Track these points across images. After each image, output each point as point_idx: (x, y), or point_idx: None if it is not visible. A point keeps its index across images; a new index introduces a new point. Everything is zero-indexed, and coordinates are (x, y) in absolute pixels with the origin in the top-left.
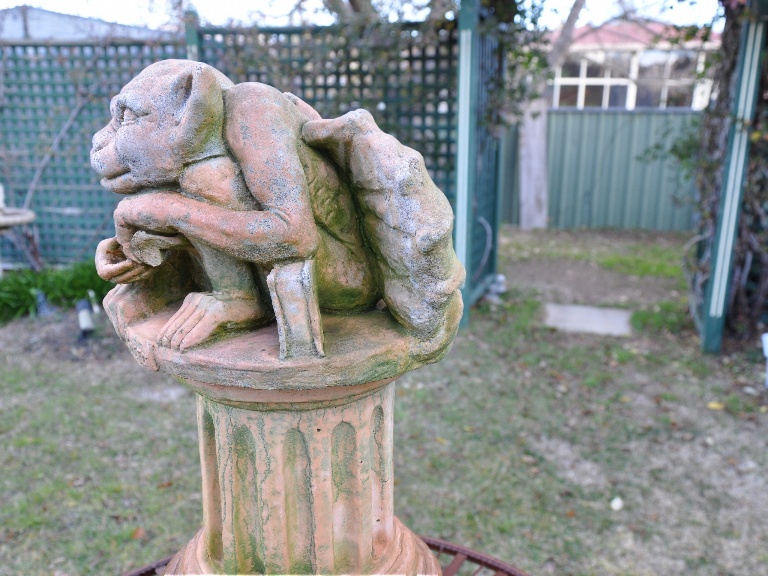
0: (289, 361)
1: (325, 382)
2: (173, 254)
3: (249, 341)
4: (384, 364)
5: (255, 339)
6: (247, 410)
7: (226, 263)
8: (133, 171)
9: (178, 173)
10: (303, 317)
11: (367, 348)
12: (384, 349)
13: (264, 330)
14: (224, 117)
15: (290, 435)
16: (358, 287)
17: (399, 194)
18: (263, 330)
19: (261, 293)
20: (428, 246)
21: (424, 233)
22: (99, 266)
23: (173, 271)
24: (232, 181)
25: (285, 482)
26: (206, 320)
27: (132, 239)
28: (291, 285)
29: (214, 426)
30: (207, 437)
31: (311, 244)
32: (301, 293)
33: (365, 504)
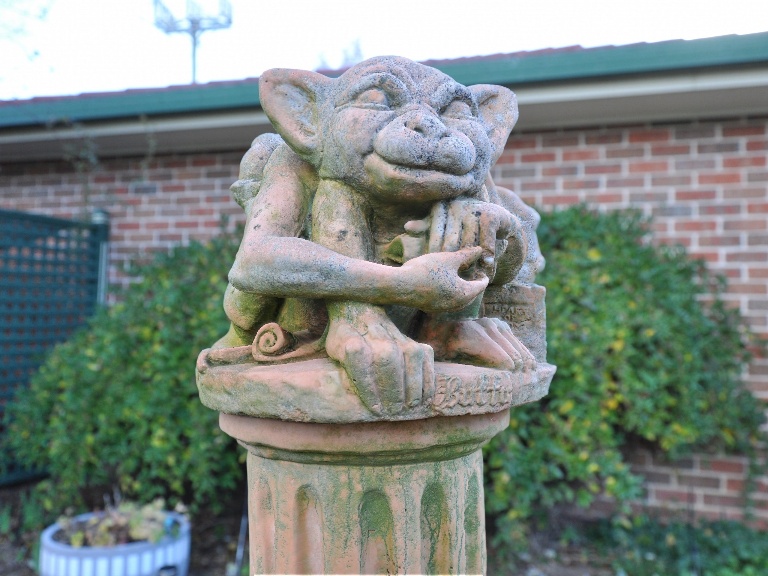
0: None
1: None
2: None
3: None
4: None
5: None
6: None
7: None
8: (480, 171)
9: None
10: None
11: None
12: None
13: None
14: None
15: None
16: None
17: (532, 230)
18: None
19: None
20: None
21: None
22: None
23: None
24: None
25: None
26: None
27: None
28: None
29: (450, 493)
30: None
31: None
32: None
33: None
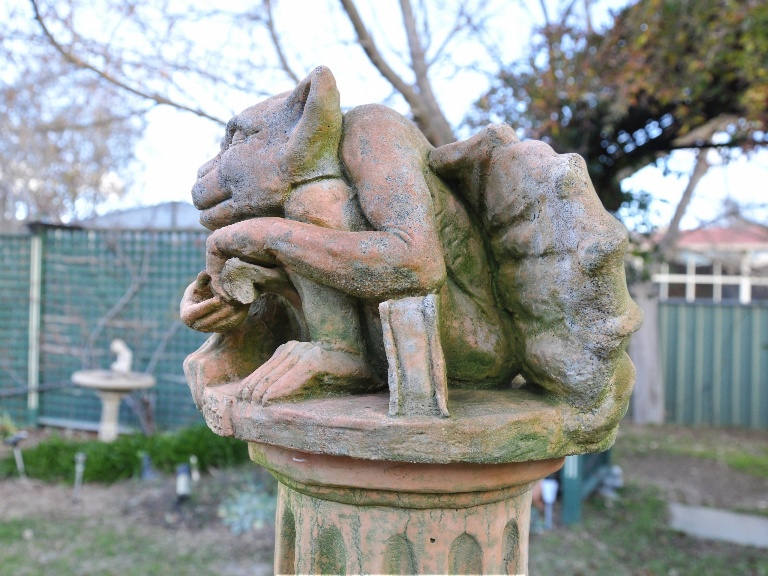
0: (401, 418)
1: (448, 453)
2: (269, 311)
3: (350, 399)
4: (529, 438)
5: (357, 399)
6: (339, 503)
7: (329, 303)
8: (234, 194)
9: (284, 195)
10: (423, 359)
11: (506, 412)
12: (529, 415)
13: (369, 395)
14: (342, 134)
15: (393, 545)
16: (490, 352)
17: (555, 198)
18: (368, 395)
19: (368, 350)
20: (596, 260)
21: (590, 243)
22: (183, 308)
23: (267, 332)
24: (345, 205)
25: None
26: (298, 367)
27: (223, 268)
28: (409, 315)
29: (295, 528)
30: (285, 547)
31: (436, 272)
32: (422, 326)
33: None
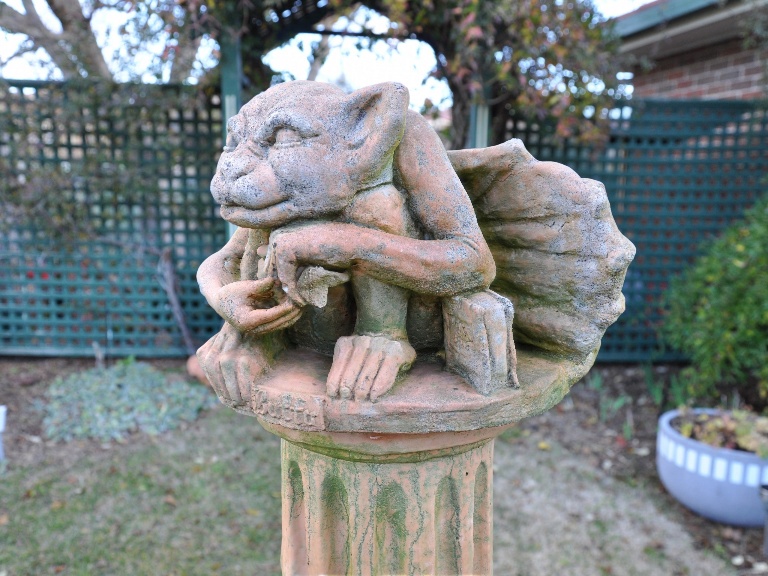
0: (494, 396)
1: (520, 414)
2: None
3: (427, 382)
4: (555, 390)
5: (429, 380)
6: (399, 464)
7: (393, 299)
8: (298, 199)
9: (348, 201)
10: (505, 347)
11: (545, 375)
12: None
13: (415, 372)
14: None
15: (440, 484)
16: None
17: (592, 218)
18: (415, 372)
19: None
20: (622, 266)
21: (619, 254)
22: (240, 313)
23: None
24: (402, 210)
25: None
26: (390, 363)
27: (305, 276)
28: (498, 314)
29: (348, 491)
30: (324, 508)
31: (493, 272)
32: (505, 322)
33: None
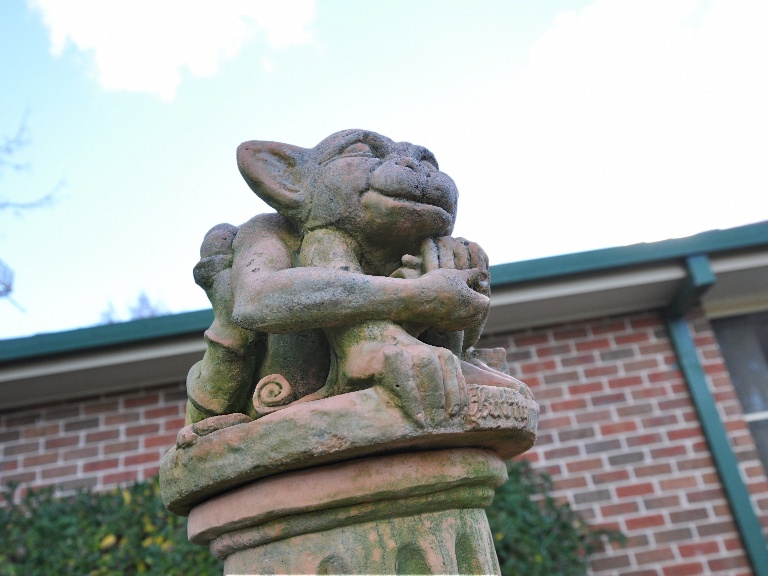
0: None
1: None
2: None
3: None
4: None
5: None
6: None
7: None
8: None
9: None
10: None
11: None
12: None
13: None
14: None
15: None
16: None
17: None
18: None
19: None
20: None
21: None
22: None
23: None
24: None
25: None
26: None
27: None
28: None
29: (479, 546)
30: None
31: None
32: None
33: None
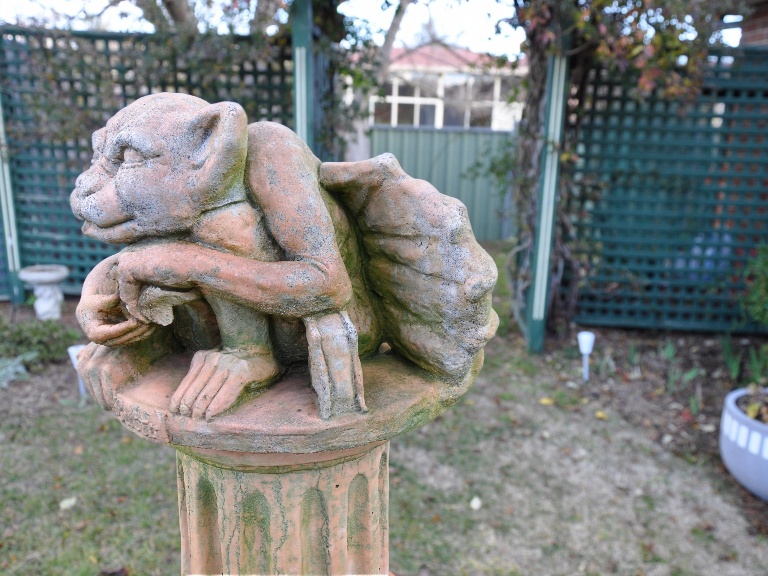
0: (334, 420)
1: (368, 438)
2: None
3: (277, 401)
4: (419, 413)
5: (281, 398)
6: (261, 474)
7: (246, 317)
8: (140, 219)
9: (194, 221)
10: (348, 373)
11: (404, 398)
12: (420, 398)
13: (280, 386)
14: (246, 160)
15: (307, 495)
16: (368, 333)
17: (448, 243)
18: (279, 386)
19: (274, 346)
20: (479, 294)
21: (476, 281)
22: (89, 328)
23: None
24: (254, 229)
25: (301, 546)
26: (232, 382)
27: (143, 297)
28: (337, 340)
29: (216, 495)
30: (201, 507)
31: (347, 294)
32: (347, 348)
33: (375, 556)
